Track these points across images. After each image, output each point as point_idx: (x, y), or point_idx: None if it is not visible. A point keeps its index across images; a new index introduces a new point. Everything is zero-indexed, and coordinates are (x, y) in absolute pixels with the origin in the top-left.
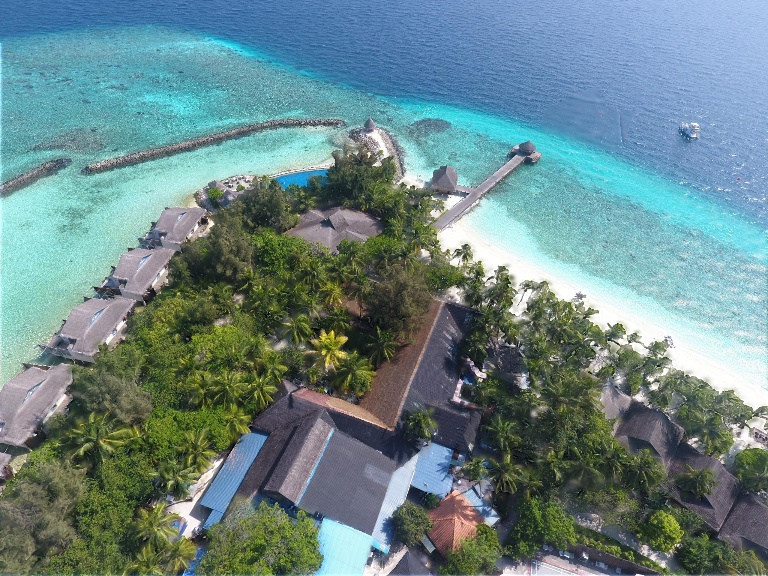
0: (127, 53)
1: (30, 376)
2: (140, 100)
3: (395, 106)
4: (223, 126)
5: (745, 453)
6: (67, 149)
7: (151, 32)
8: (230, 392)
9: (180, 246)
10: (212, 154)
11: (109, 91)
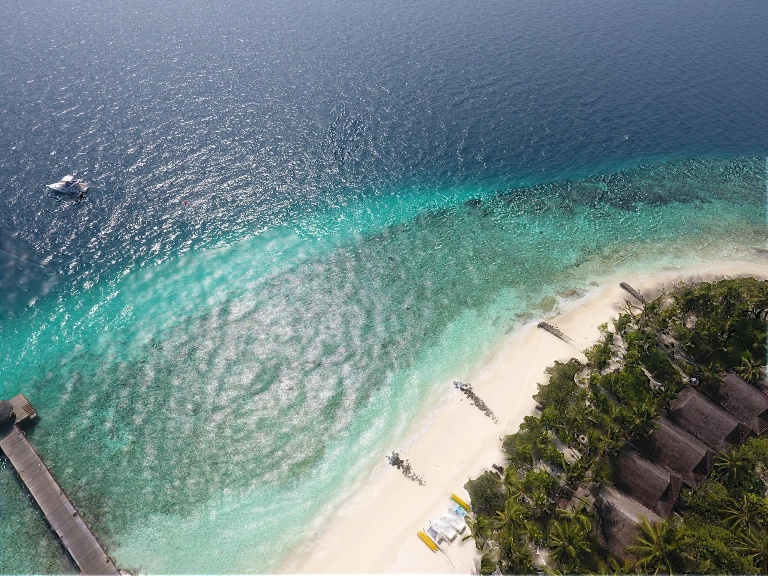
0: None
1: None
2: None
3: None
4: None
5: (623, 392)
6: None
7: None
8: None
9: None
10: None
11: None
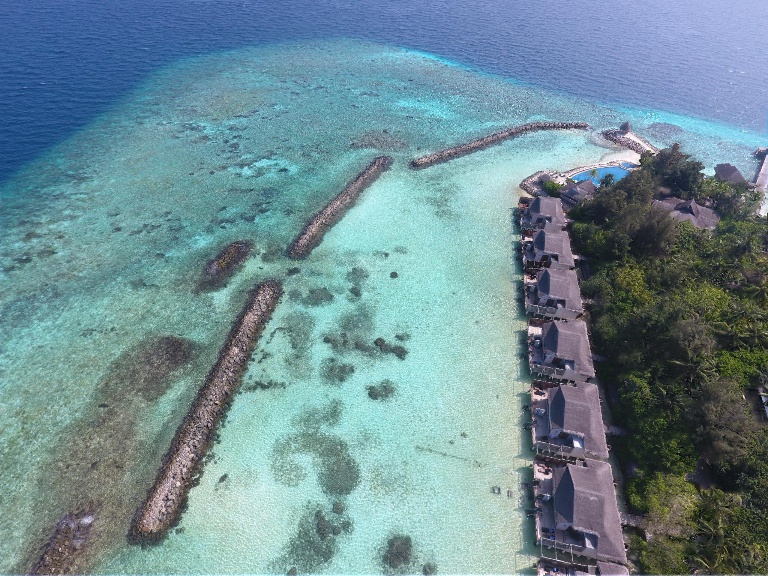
0: (349, 63)
1: (565, 326)
2: (399, 105)
3: (619, 111)
4: (489, 128)
5: None
6: (379, 148)
7: (351, 44)
8: (765, 337)
9: (562, 229)
10: (502, 153)
11: (366, 97)
